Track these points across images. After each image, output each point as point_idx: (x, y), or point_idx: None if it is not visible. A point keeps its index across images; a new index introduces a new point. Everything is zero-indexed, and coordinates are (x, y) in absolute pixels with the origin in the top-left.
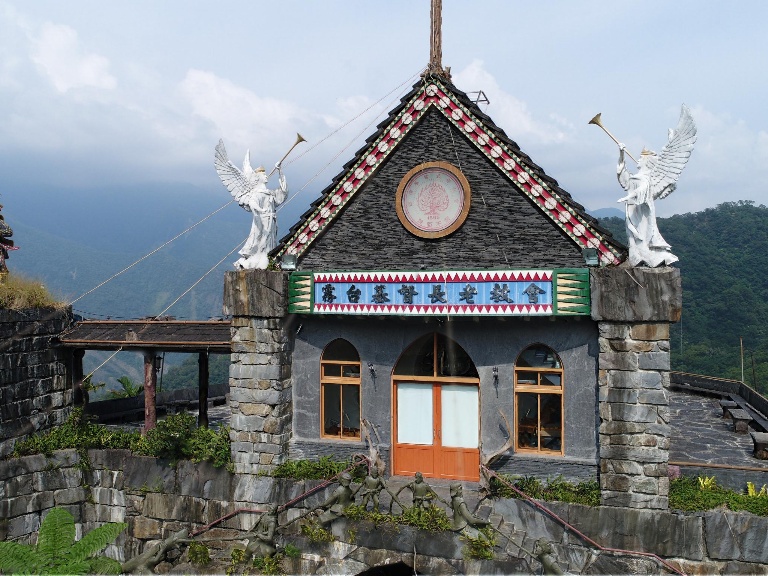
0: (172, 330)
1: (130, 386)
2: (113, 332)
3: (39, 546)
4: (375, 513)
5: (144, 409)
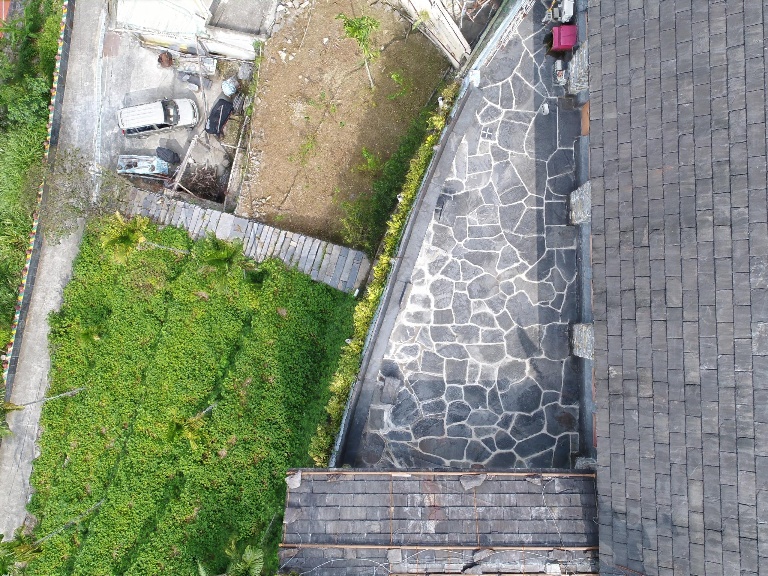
0: None
1: (219, 254)
2: None
3: None
4: None
5: (365, 413)
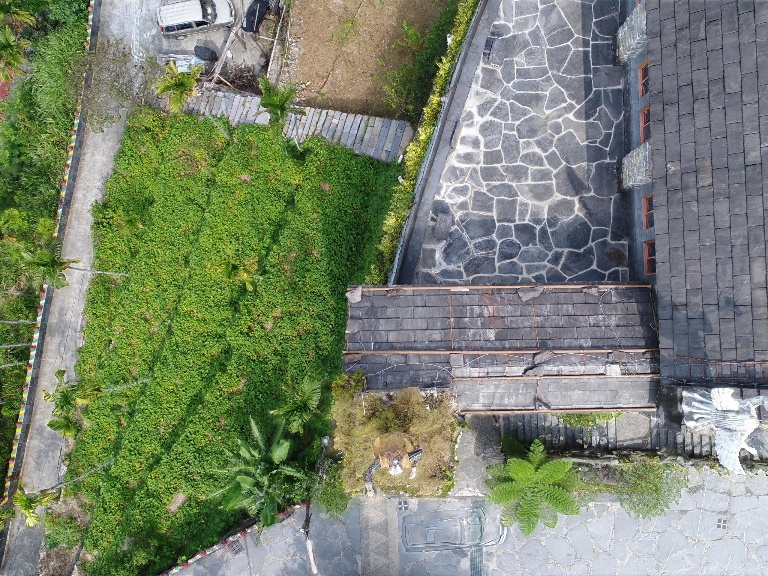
0: (572, 385)
1: (272, 98)
2: (506, 392)
3: (516, 480)
4: (766, 470)
5: (418, 250)
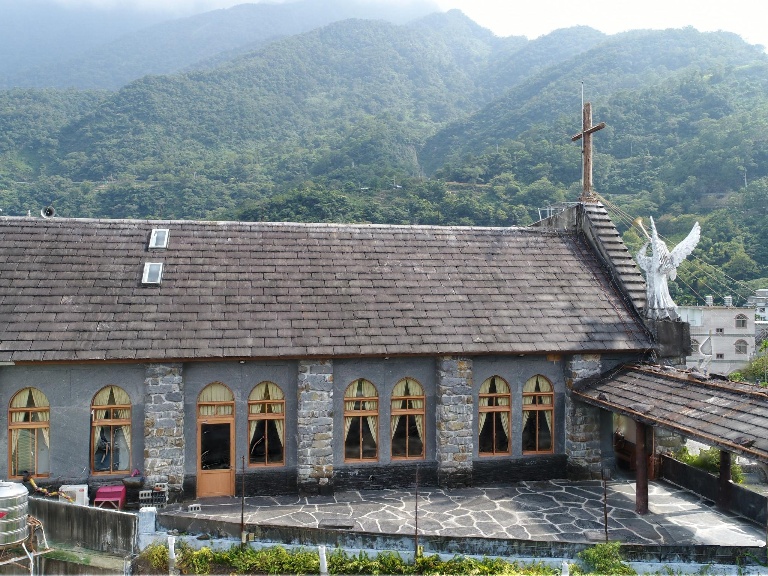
0: None
1: None
2: None
3: None
4: None
5: None
